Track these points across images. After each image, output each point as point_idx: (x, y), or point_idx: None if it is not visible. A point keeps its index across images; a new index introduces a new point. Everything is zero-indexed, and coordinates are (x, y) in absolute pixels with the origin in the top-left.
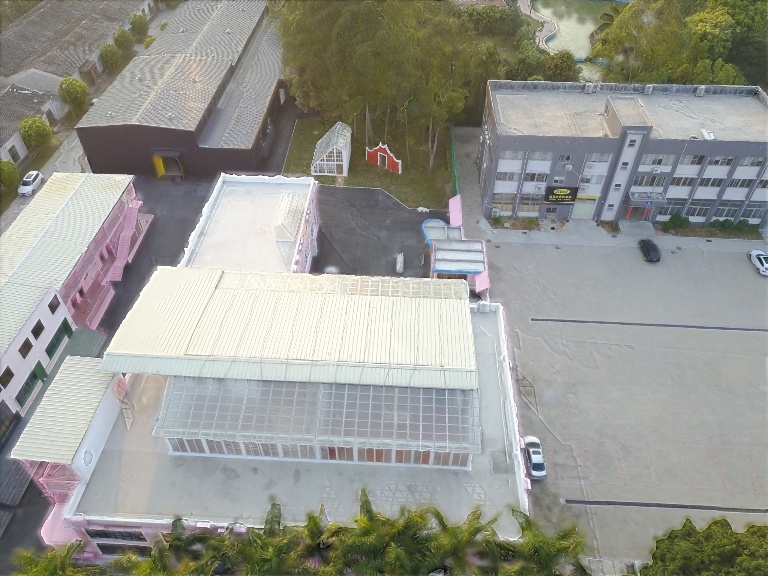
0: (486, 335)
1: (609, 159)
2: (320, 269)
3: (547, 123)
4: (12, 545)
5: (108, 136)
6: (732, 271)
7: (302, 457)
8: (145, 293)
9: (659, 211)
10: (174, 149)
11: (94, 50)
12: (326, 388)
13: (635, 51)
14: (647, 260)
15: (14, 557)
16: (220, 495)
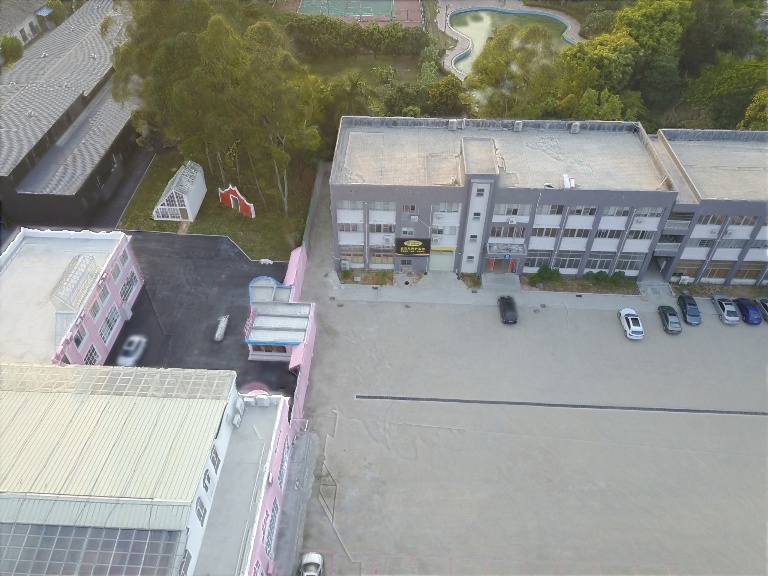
0: (256, 437)
1: (459, 209)
2: (129, 337)
3: (395, 167)
4: None
5: None
6: (597, 333)
7: None
8: None
9: (525, 263)
10: None
11: None
12: (3, 529)
13: (507, 82)
14: (503, 321)
15: None
16: None
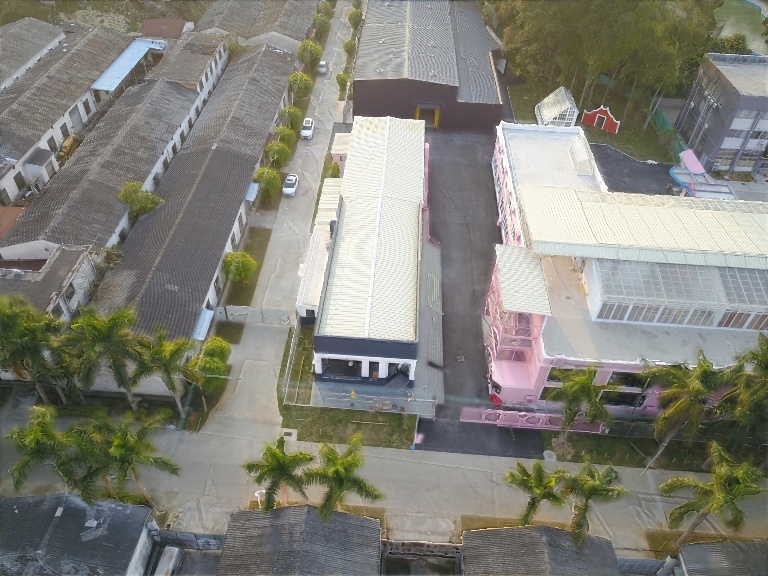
0: None
1: None
2: None
3: None
4: (456, 393)
5: (380, 89)
6: None
7: (701, 324)
8: (527, 202)
9: None
10: (435, 103)
11: (310, 19)
12: (721, 270)
13: None
14: None
15: (462, 401)
16: (651, 348)
